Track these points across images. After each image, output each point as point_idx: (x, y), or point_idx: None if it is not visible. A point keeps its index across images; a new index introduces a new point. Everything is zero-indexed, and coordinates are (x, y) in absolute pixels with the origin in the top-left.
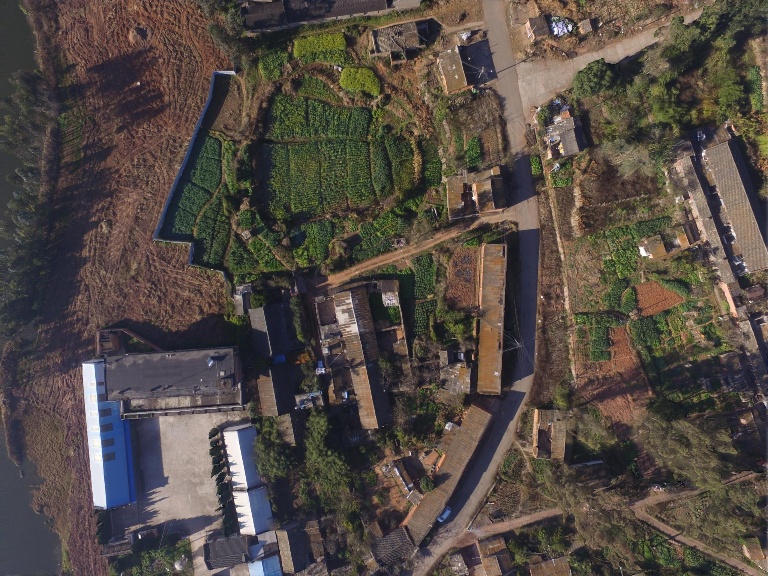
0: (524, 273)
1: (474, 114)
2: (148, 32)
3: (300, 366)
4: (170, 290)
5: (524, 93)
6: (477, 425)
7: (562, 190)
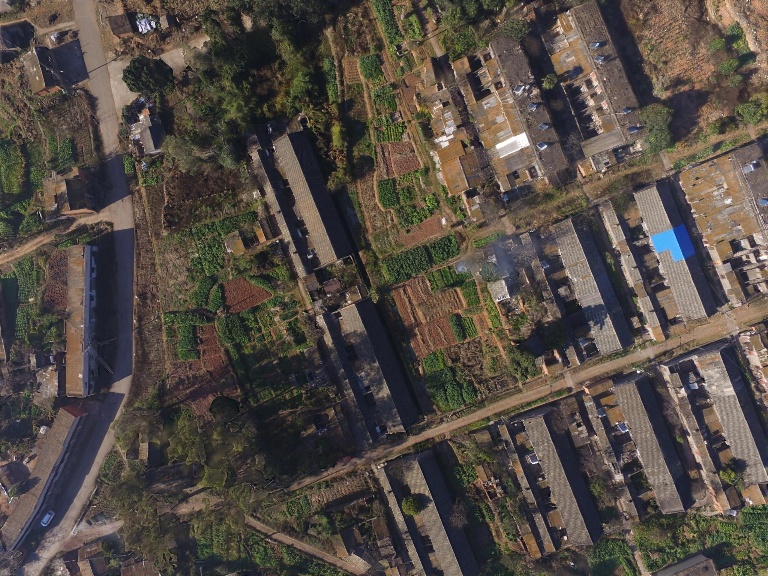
0: (120, 273)
1: (66, 115)
2: None
3: None
4: None
5: (116, 92)
6: (63, 428)
7: (152, 188)
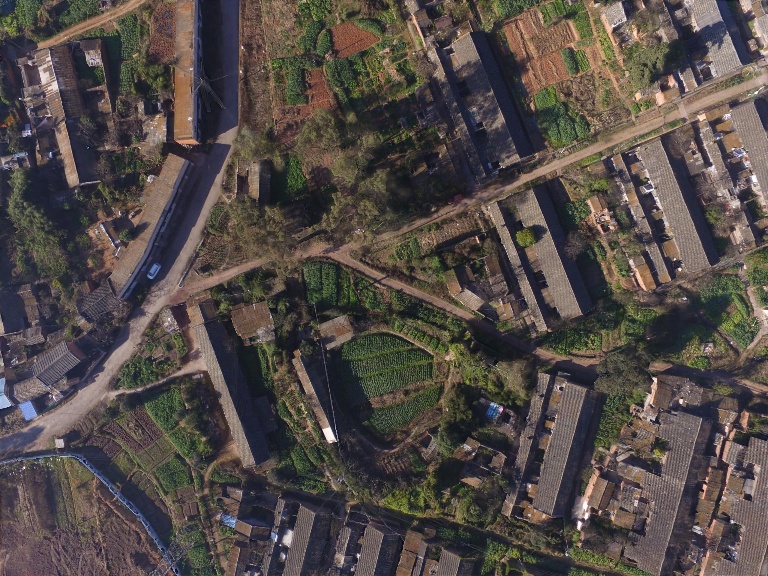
0: (225, 25)
1: None
2: None
3: (6, 129)
4: None
5: None
6: (173, 172)
7: None
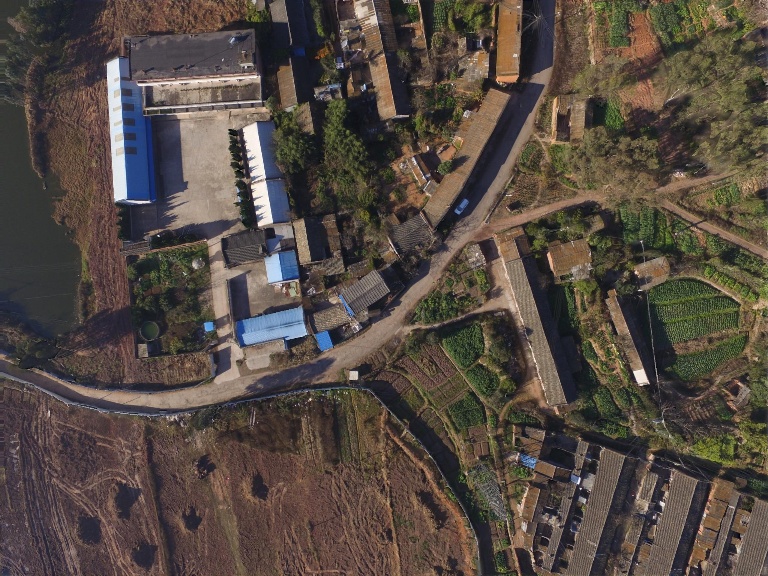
0: None
1: None
2: None
3: (319, 60)
4: (193, 1)
5: None
6: (495, 107)
7: None
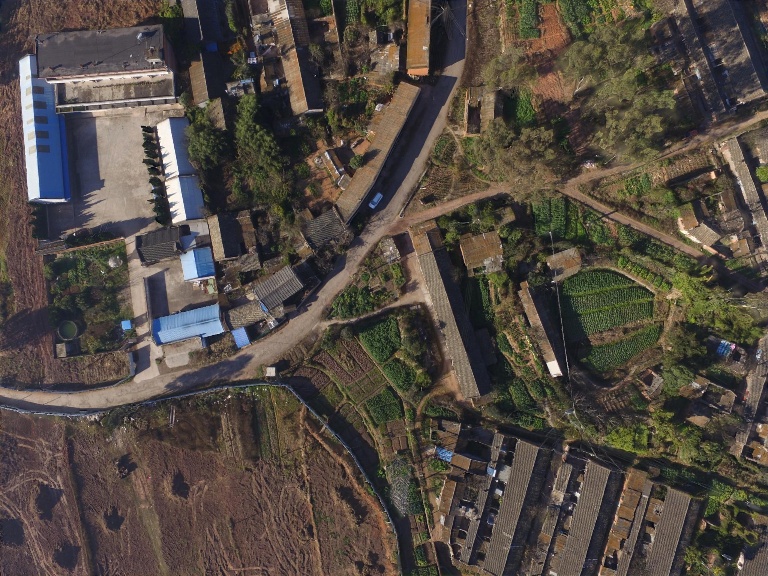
0: None
1: None
2: None
3: (232, 55)
4: None
5: None
6: (406, 100)
7: None
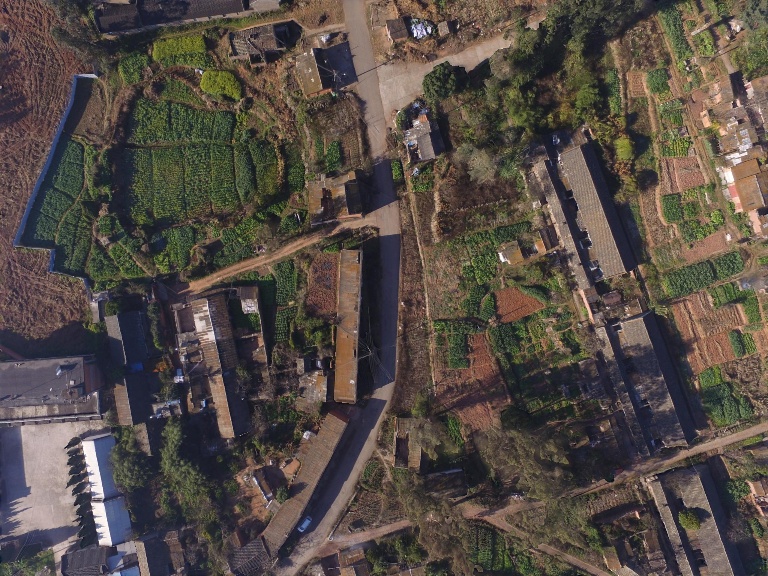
0: (385, 279)
1: (334, 118)
2: (9, 35)
3: (158, 374)
4: (32, 297)
5: (385, 96)
6: (333, 434)
7: (422, 195)
